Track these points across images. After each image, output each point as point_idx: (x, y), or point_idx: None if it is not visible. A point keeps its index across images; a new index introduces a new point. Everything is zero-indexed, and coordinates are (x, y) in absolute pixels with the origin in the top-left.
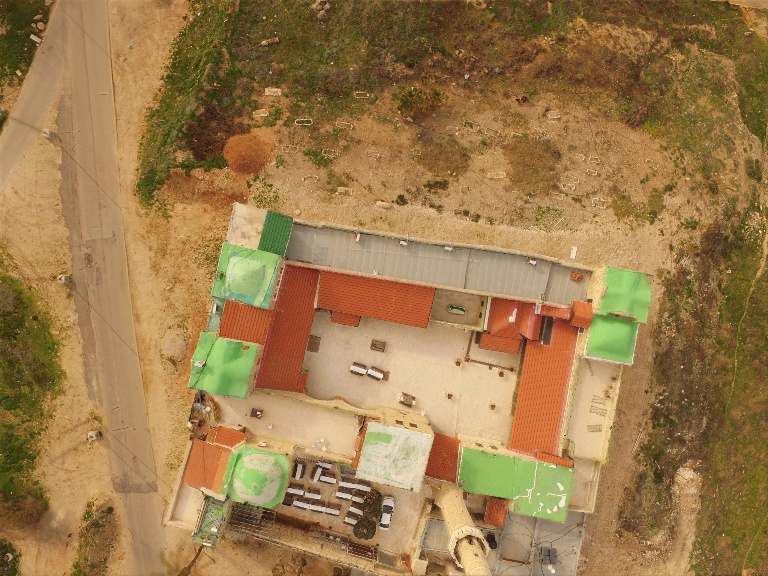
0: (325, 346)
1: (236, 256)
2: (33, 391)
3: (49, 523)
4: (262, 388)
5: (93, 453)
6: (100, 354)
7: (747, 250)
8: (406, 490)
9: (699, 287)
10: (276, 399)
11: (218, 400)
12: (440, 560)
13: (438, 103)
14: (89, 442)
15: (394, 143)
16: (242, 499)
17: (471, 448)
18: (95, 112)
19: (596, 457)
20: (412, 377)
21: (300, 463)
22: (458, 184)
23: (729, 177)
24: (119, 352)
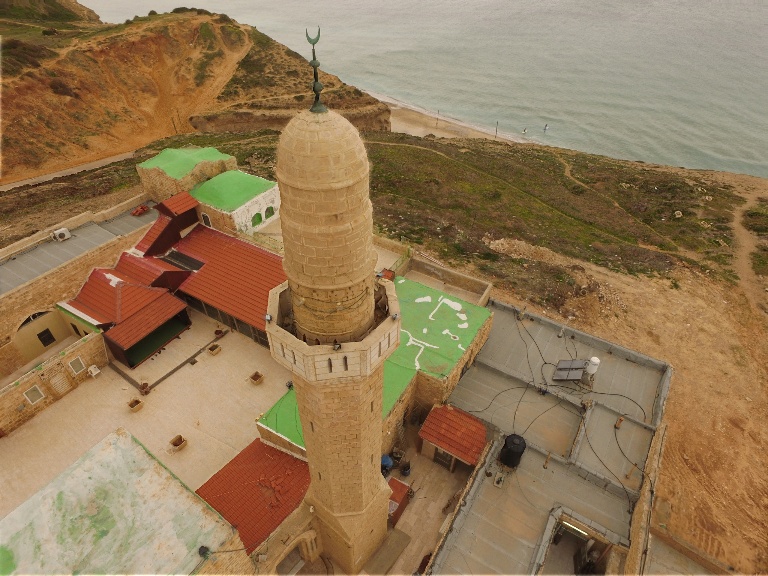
0: None
1: None
2: None
3: None
4: None
5: None
6: None
7: None
8: (193, 575)
9: None
10: None
11: None
12: None
13: None
14: None
15: None
16: None
17: (271, 409)
18: None
19: None
20: None
21: None
22: None
23: None
24: None
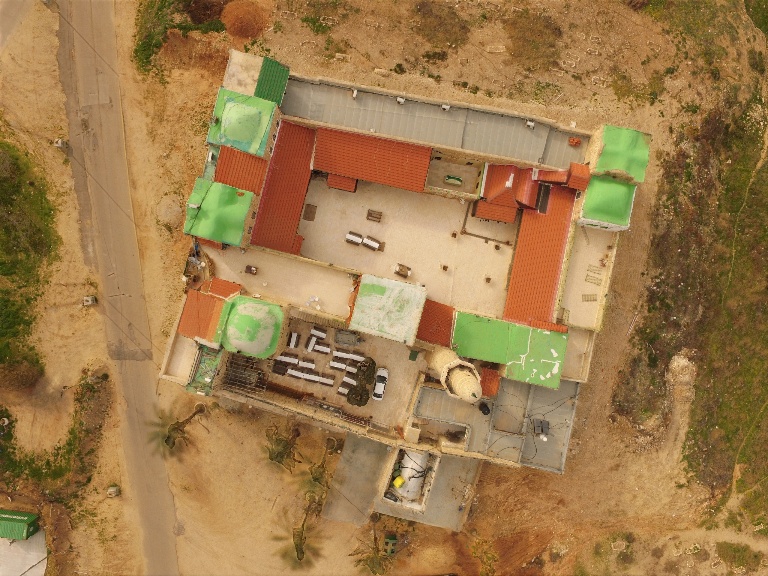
0: (321, 215)
1: (232, 102)
2: (29, 257)
3: (45, 389)
4: (257, 245)
5: (89, 319)
6: (96, 220)
7: (748, 141)
8: (399, 342)
9: (698, 172)
10: (271, 257)
11: (213, 257)
12: (433, 435)
13: None
14: (85, 308)
15: (393, 13)
16: (236, 348)
17: (465, 313)
18: None
19: (590, 327)
20: (408, 249)
21: (295, 332)
22: (457, 56)
23: (731, 65)
24: (115, 218)
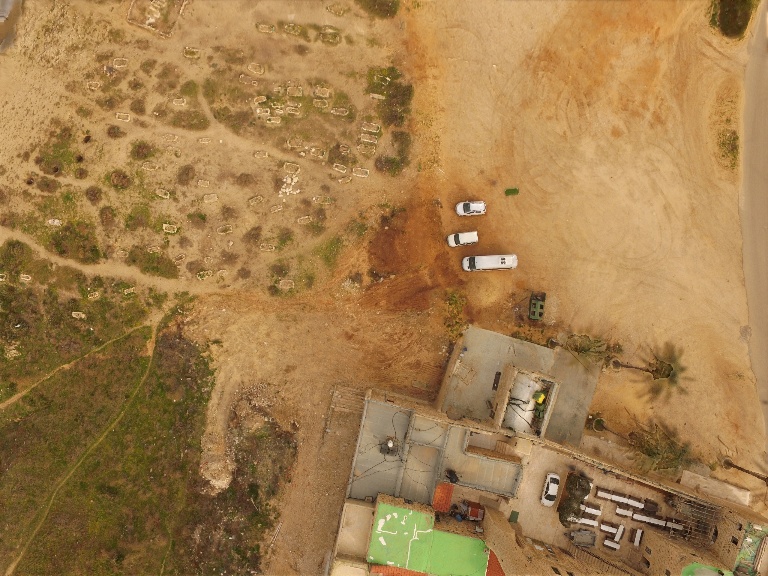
0: None
1: None
2: None
3: None
4: None
5: None
6: None
7: None
8: None
9: None
10: None
11: None
12: None
13: None
14: None
15: None
16: (723, 575)
17: None
18: None
19: None
20: None
21: None
22: None
23: None
24: None
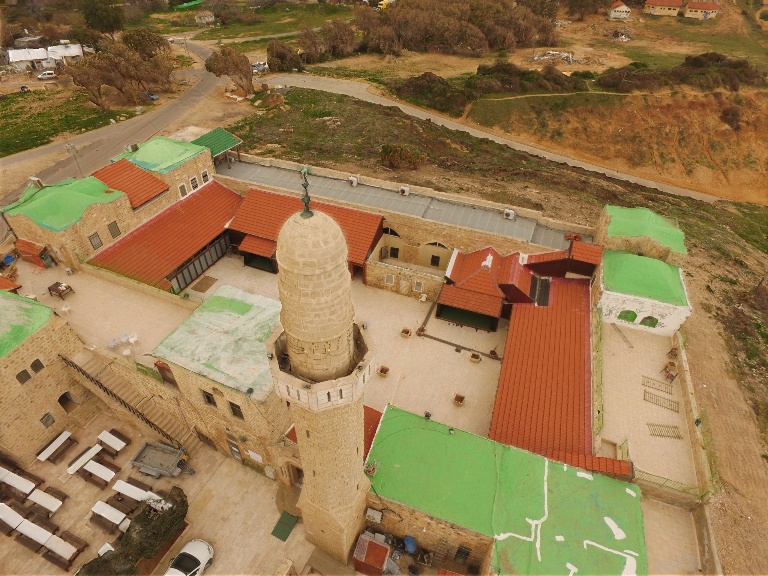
0: None
1: None
2: None
3: None
4: None
5: None
6: None
7: None
8: (237, 391)
9: None
10: (104, 284)
11: (22, 273)
12: None
13: (417, 157)
14: None
15: None
16: None
17: (403, 411)
18: (121, 146)
19: None
20: None
21: None
22: None
23: None
24: None
